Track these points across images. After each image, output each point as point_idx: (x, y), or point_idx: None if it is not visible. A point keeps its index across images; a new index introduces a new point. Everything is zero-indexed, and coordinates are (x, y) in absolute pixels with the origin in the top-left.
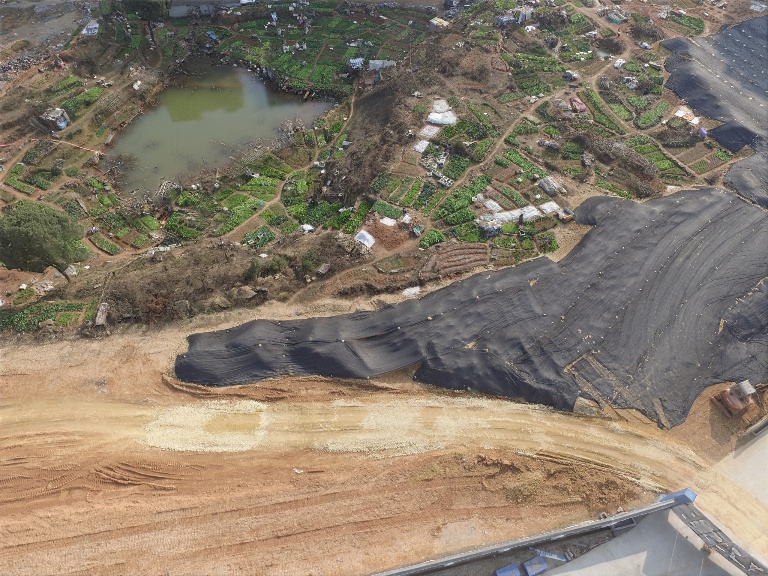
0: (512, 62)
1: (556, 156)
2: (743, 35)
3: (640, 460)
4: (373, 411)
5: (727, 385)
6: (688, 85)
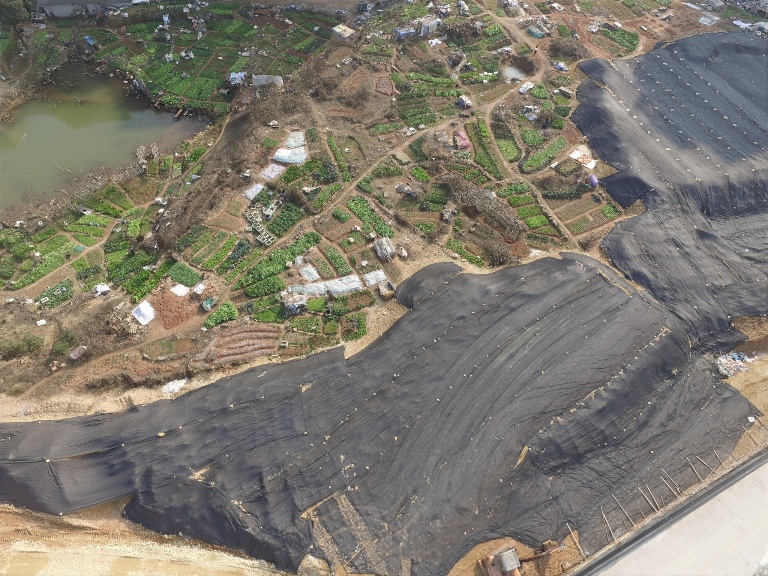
0: (400, 84)
1: (413, 206)
2: (674, 57)
3: None
4: (55, 560)
5: (504, 542)
6: (593, 119)
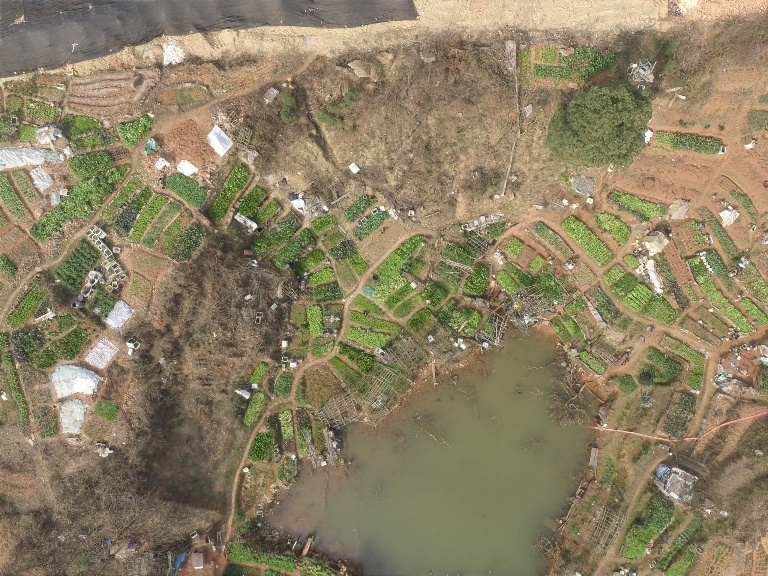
0: None
1: None
2: None
3: None
4: None
5: None
6: None
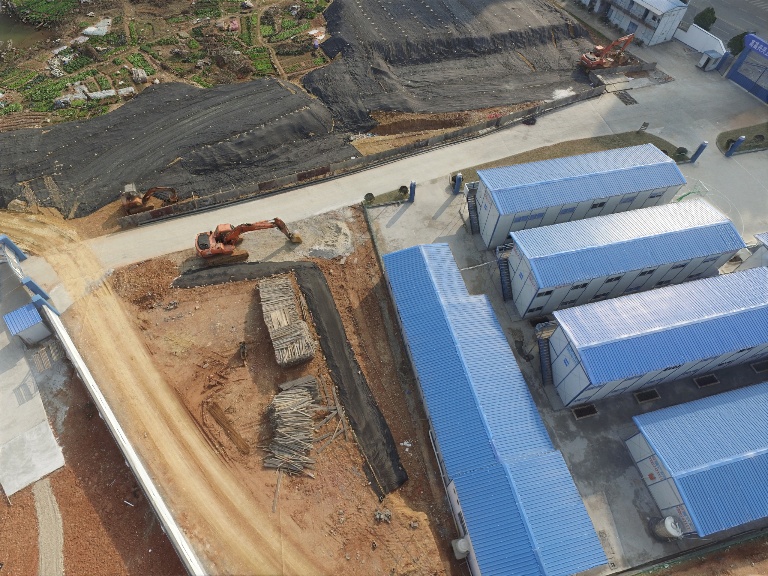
0: None
1: (178, 60)
2: None
3: (30, 236)
4: None
5: None
6: (333, 10)
